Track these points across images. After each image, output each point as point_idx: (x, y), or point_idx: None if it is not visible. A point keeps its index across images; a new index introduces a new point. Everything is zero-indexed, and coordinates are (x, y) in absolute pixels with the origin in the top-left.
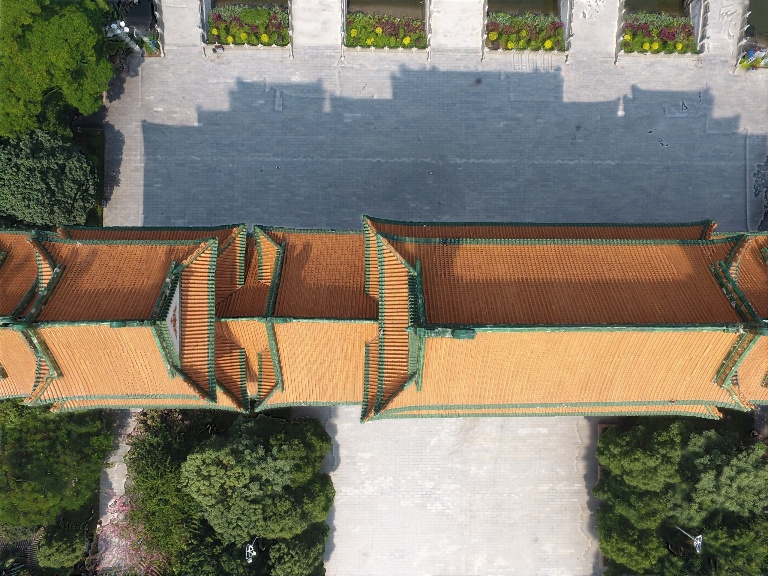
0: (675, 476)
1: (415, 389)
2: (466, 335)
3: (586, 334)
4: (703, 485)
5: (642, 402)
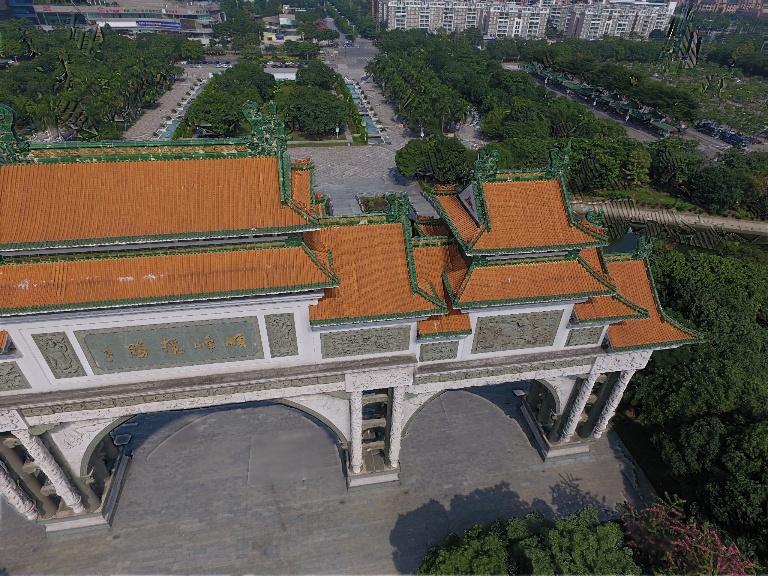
0: (499, 572)
1: None
2: (1, 105)
3: (147, 165)
4: (540, 574)
5: (224, 232)
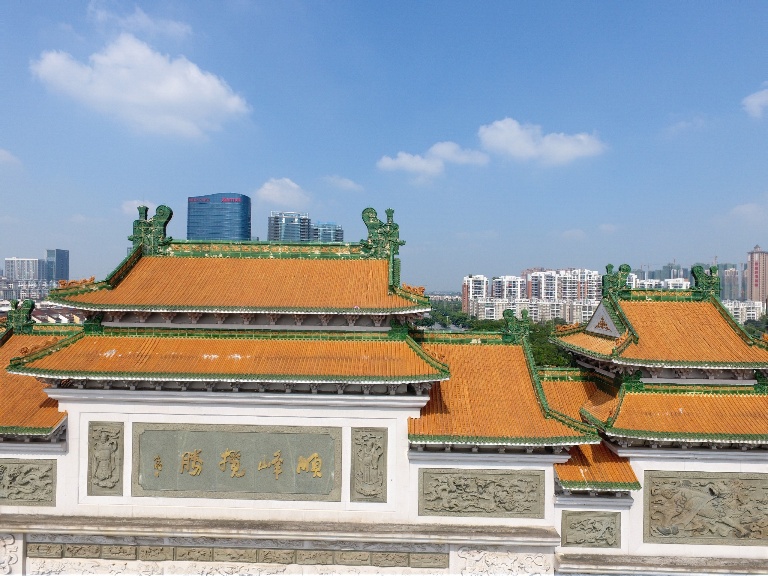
0: None
1: (104, 294)
2: None
3: (265, 261)
4: None
5: None
